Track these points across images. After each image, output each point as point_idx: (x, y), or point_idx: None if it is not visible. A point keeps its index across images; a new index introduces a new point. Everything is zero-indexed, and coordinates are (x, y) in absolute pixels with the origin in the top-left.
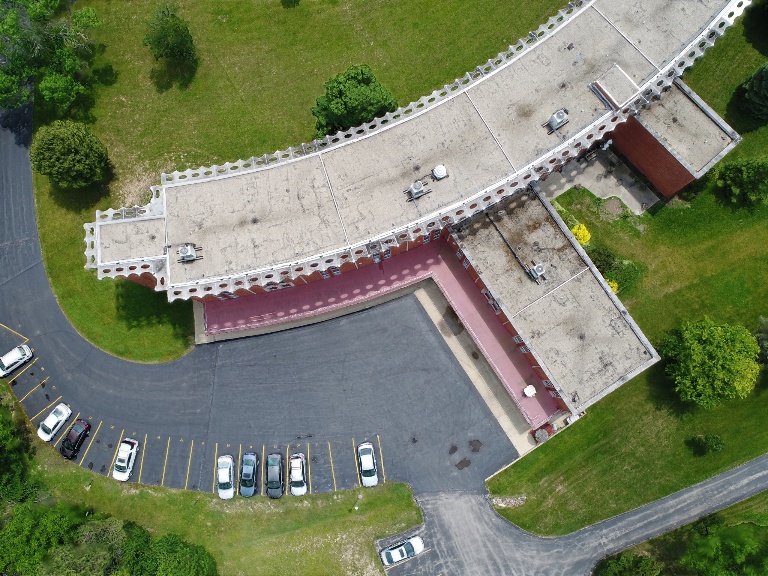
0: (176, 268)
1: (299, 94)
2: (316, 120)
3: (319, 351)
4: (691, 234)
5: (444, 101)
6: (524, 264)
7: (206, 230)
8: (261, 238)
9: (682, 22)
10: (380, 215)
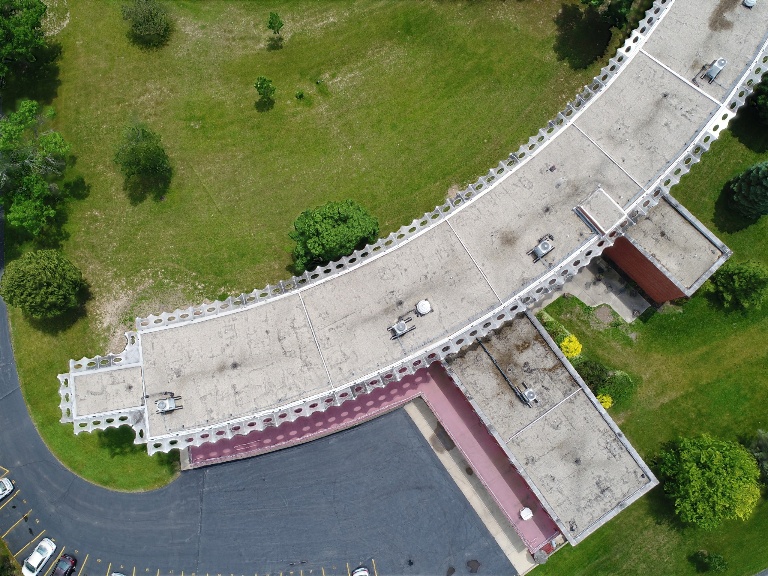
0: (155, 419)
1: (277, 203)
2: None
3: (309, 472)
4: (684, 340)
5: (425, 231)
6: (515, 386)
7: (184, 377)
8: (242, 384)
9: (666, 138)
10: (364, 355)
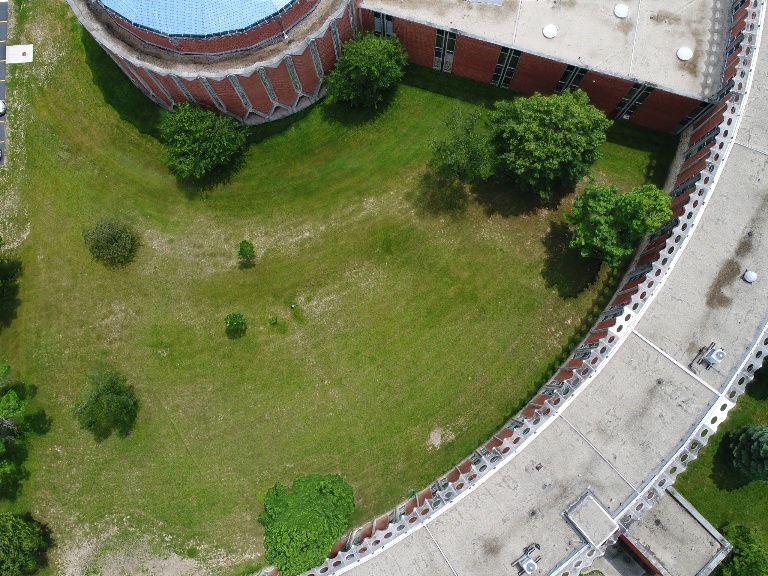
0: None
1: (249, 445)
2: (269, 477)
3: None
4: None
5: (402, 538)
6: None
7: None
8: None
9: (661, 432)
10: None
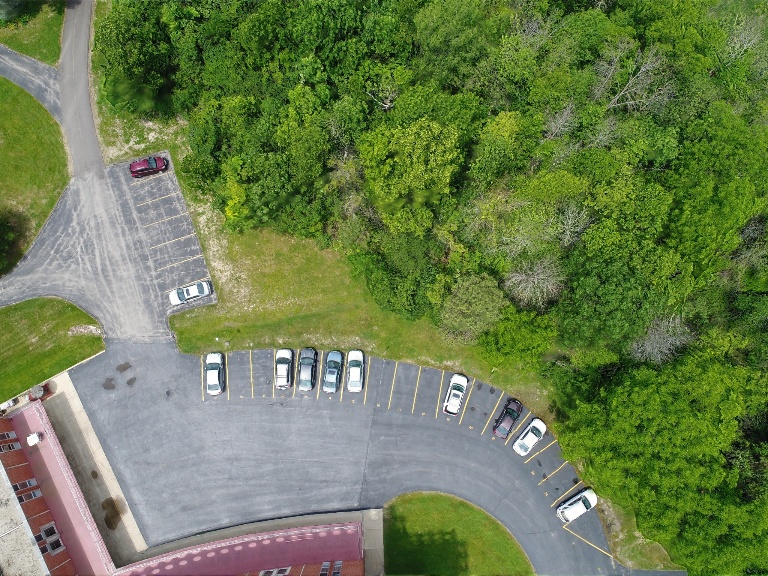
0: None
1: None
2: None
3: (254, 492)
4: None
5: None
6: None
7: None
8: None
9: None
10: None
